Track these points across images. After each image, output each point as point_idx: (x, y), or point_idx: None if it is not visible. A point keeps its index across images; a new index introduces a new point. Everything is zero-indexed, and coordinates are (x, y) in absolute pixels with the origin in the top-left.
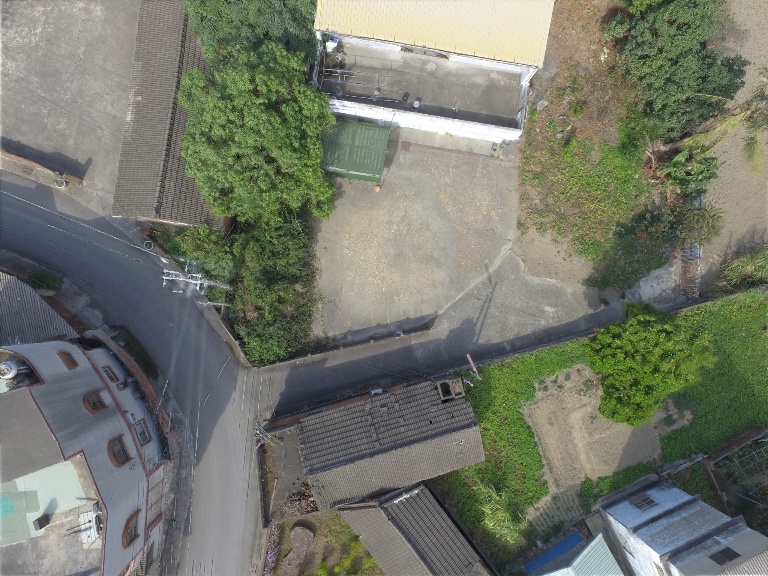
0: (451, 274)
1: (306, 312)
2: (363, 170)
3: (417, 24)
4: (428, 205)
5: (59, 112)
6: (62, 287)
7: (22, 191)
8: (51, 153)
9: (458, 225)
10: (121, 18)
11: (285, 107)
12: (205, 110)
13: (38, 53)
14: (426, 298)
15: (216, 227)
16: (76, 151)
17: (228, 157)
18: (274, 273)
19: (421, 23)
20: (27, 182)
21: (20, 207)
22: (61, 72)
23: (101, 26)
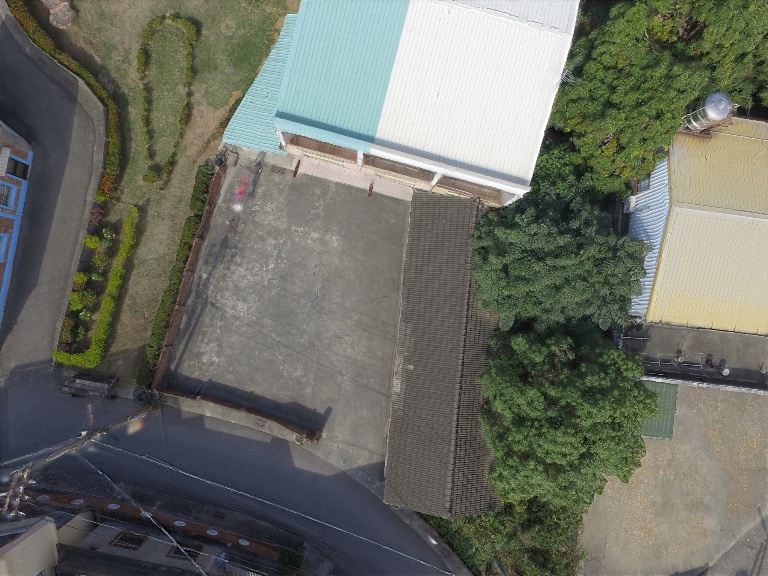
0: (722, 521)
1: (570, 574)
2: (651, 433)
3: (761, 312)
4: (696, 446)
5: (296, 358)
6: (304, 554)
7: (256, 446)
8: (287, 403)
9: (728, 466)
10: (359, 248)
11: (626, 423)
12: (527, 420)
13: (271, 292)
14: (696, 550)
15: (497, 509)
16: (314, 400)
17: (564, 483)
18: (549, 546)
19: (766, 311)
20: (261, 436)
21: (255, 465)
22: (297, 313)
23: (338, 258)
